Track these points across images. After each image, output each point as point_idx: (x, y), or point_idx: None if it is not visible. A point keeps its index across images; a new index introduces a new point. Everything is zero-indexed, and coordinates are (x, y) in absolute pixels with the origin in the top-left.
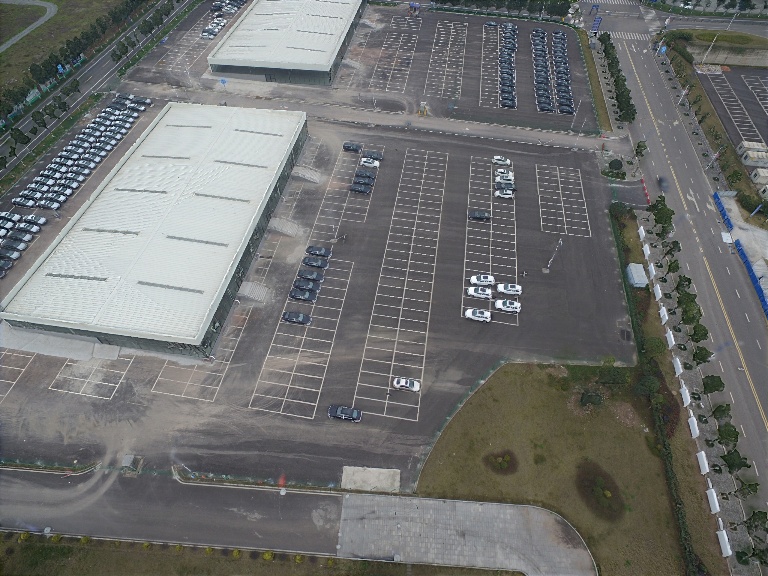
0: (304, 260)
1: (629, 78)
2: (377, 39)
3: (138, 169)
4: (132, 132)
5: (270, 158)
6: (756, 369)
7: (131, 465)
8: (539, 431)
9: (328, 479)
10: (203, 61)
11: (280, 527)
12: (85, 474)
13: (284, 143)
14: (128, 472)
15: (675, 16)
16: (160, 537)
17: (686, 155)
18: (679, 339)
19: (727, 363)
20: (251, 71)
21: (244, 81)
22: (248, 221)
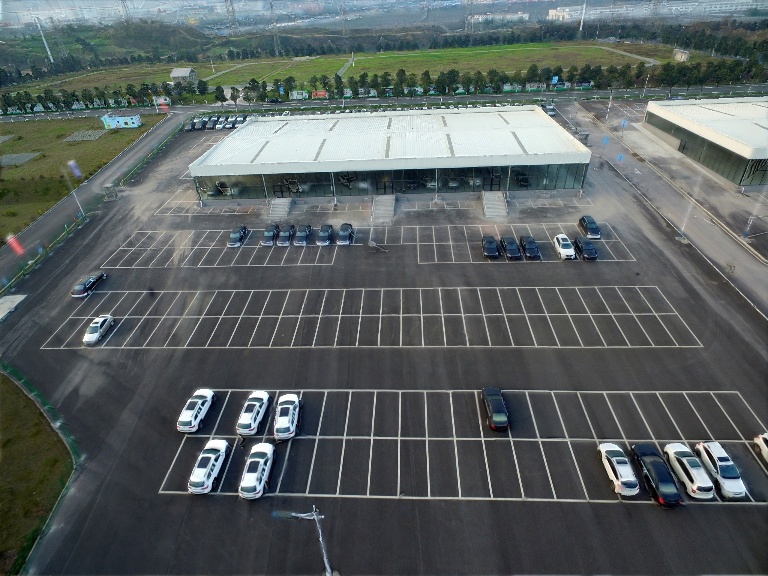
0: None
1: None
2: None
3: (422, 118)
4: None
5: (473, 154)
6: None
7: (105, 189)
8: None
9: (22, 287)
10: None
11: None
12: (119, 184)
13: None
14: None
15: None
16: None
17: None
18: None
19: None
20: (674, 131)
21: (658, 141)
22: None
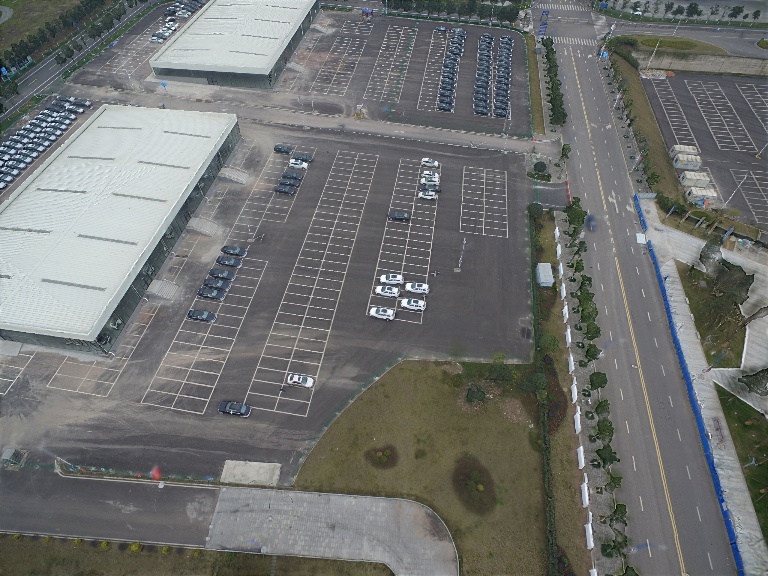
0: (217, 259)
1: (570, 82)
2: (326, 43)
3: (62, 169)
4: (67, 134)
5: (194, 159)
6: (649, 367)
7: (12, 458)
8: (425, 426)
9: (208, 473)
10: (149, 64)
11: (153, 519)
12: None
13: (210, 144)
14: (10, 465)
15: (624, 22)
16: (32, 529)
17: (614, 158)
18: (579, 337)
19: (622, 361)
20: (193, 74)
21: (187, 84)
22: (162, 220)
